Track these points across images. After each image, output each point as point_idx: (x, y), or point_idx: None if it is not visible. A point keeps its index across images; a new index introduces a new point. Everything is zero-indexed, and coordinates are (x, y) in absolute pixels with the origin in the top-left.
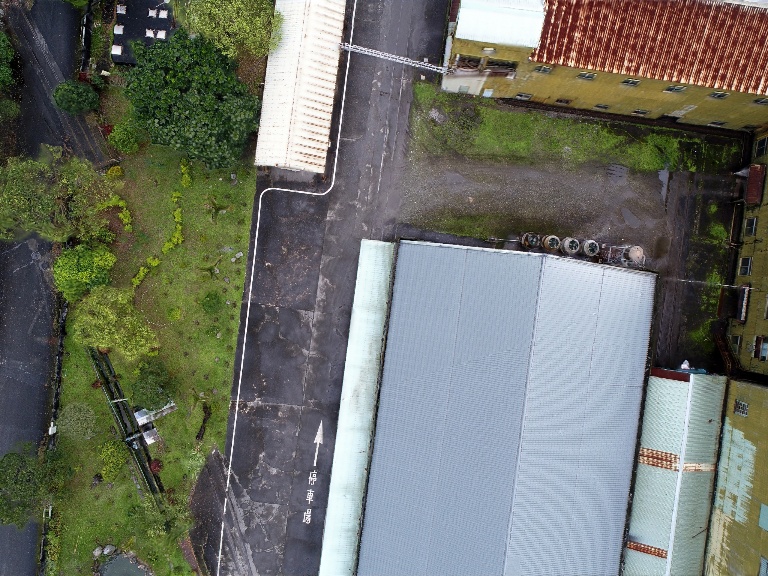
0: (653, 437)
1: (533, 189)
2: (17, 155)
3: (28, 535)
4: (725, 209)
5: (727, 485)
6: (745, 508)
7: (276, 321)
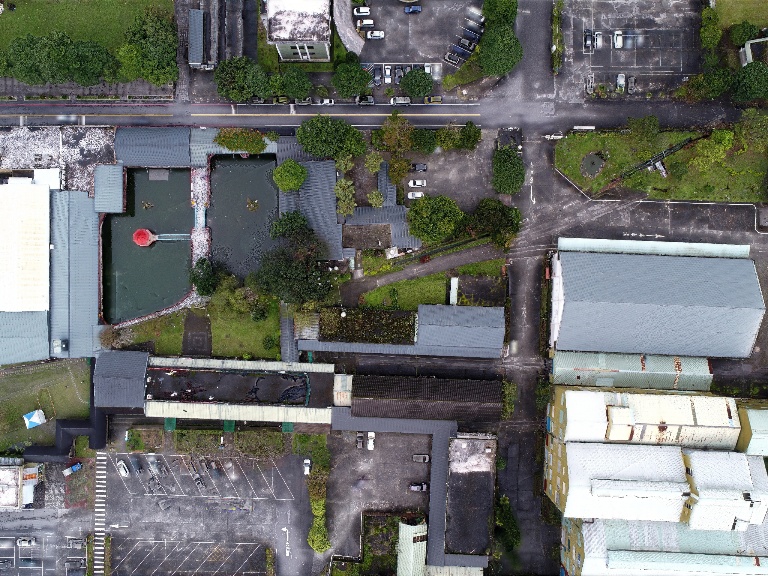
0: (685, 363)
1: (766, 314)
2: (759, 106)
3: (608, 123)
4: (765, 392)
5: None
6: None
7: (703, 215)
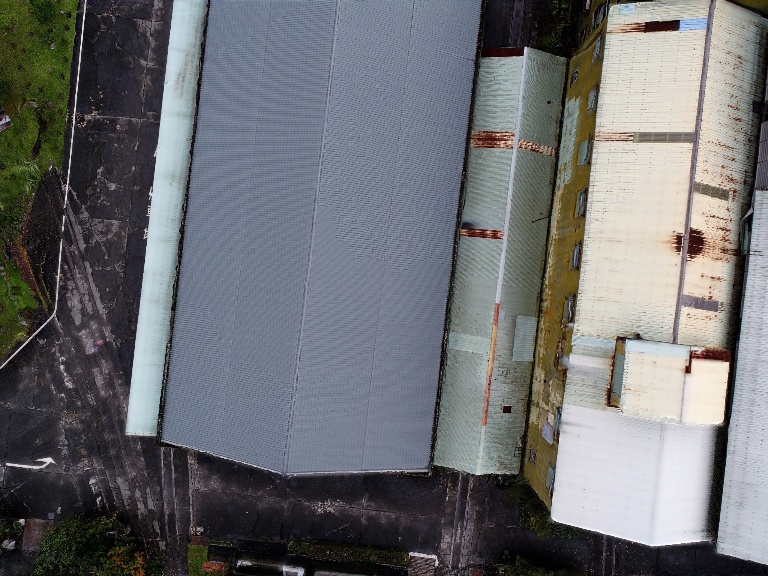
0: (489, 119)
1: None
2: None
3: None
4: None
5: (562, 159)
6: (570, 162)
7: (112, 31)
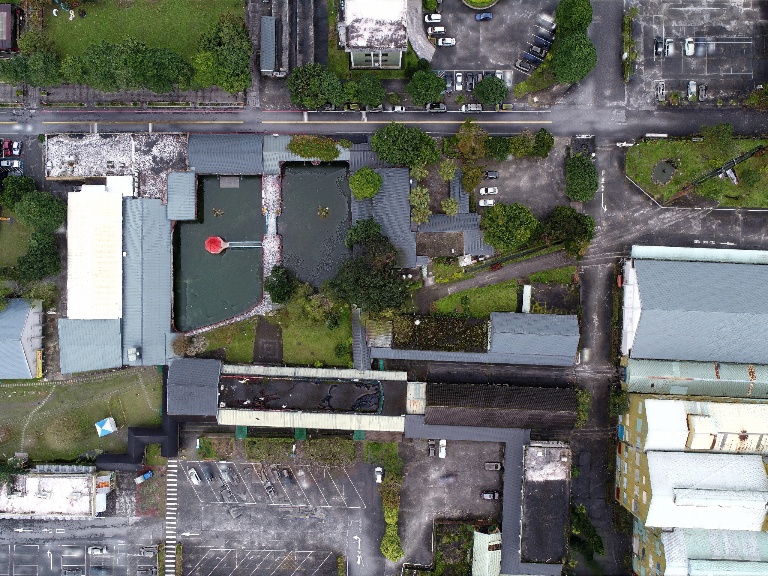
0: (759, 371)
1: None
2: None
3: (679, 131)
4: None
5: None
6: None
7: None
